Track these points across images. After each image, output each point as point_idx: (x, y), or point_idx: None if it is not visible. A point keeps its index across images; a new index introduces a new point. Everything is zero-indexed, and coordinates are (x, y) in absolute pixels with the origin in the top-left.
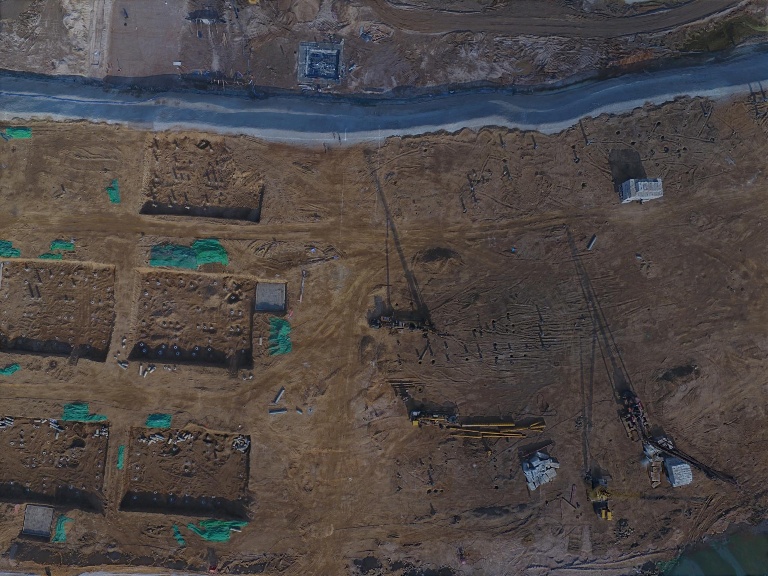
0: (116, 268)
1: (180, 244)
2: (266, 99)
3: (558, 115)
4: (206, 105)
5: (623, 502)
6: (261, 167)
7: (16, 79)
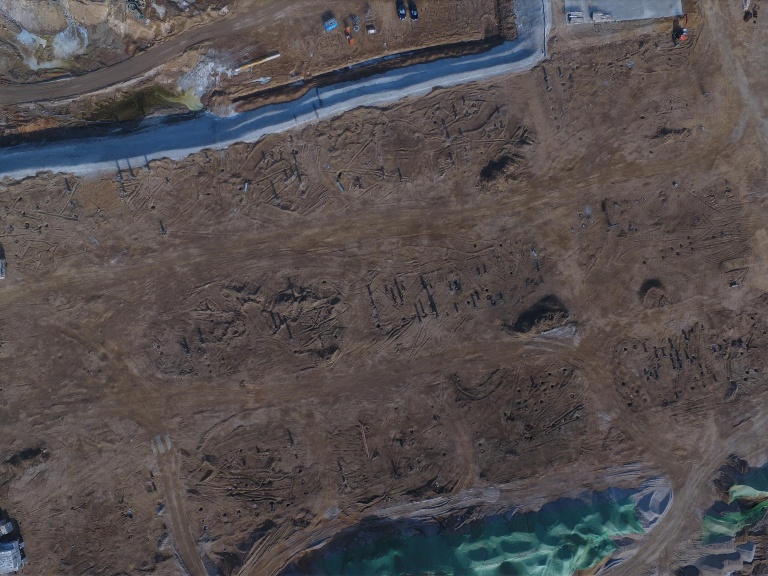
0: None
1: None
2: None
3: None
4: None
5: None
6: None
7: None
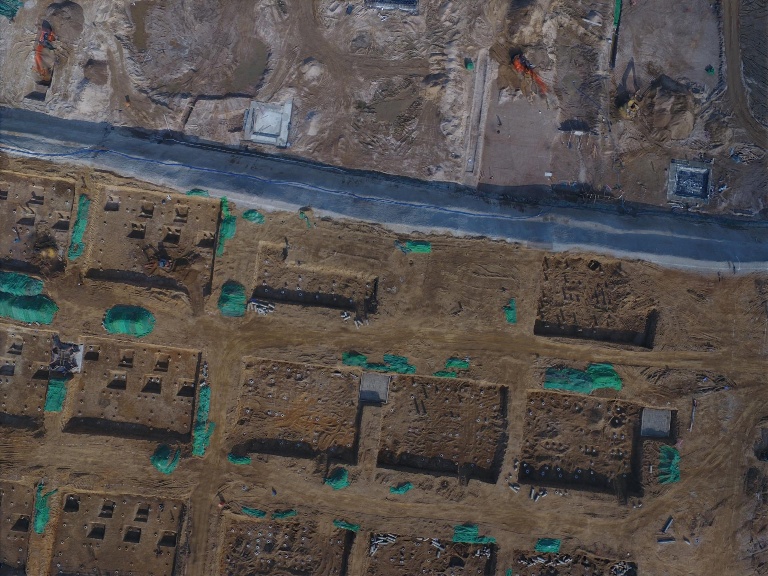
0: (509, 389)
1: (574, 367)
2: (641, 217)
3: None
4: (594, 224)
5: None
6: (656, 293)
7: (395, 184)
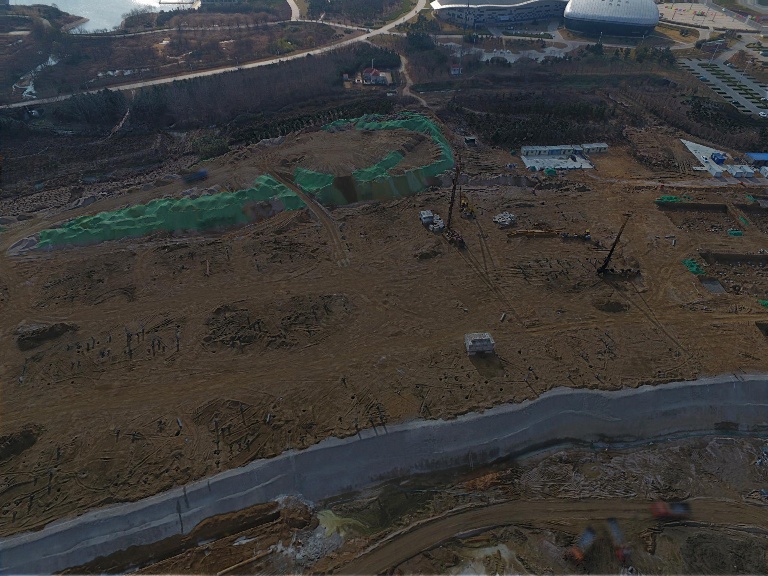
0: None
1: None
2: None
3: (556, 405)
4: None
5: None
6: None
7: None
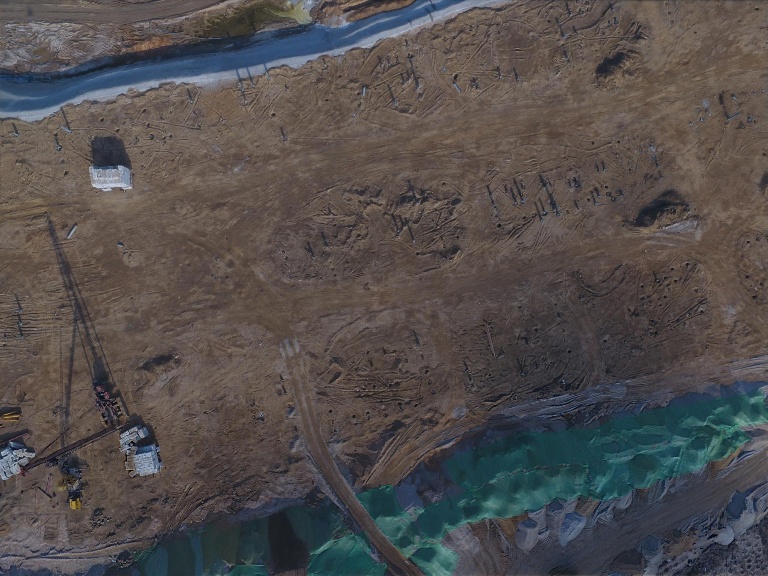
0: None
1: None
2: None
3: (46, 102)
4: None
5: (100, 491)
6: None
7: None
